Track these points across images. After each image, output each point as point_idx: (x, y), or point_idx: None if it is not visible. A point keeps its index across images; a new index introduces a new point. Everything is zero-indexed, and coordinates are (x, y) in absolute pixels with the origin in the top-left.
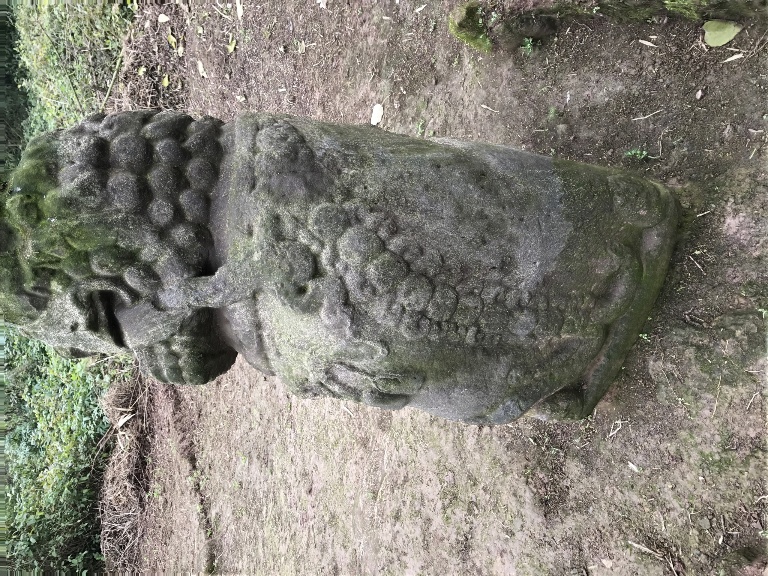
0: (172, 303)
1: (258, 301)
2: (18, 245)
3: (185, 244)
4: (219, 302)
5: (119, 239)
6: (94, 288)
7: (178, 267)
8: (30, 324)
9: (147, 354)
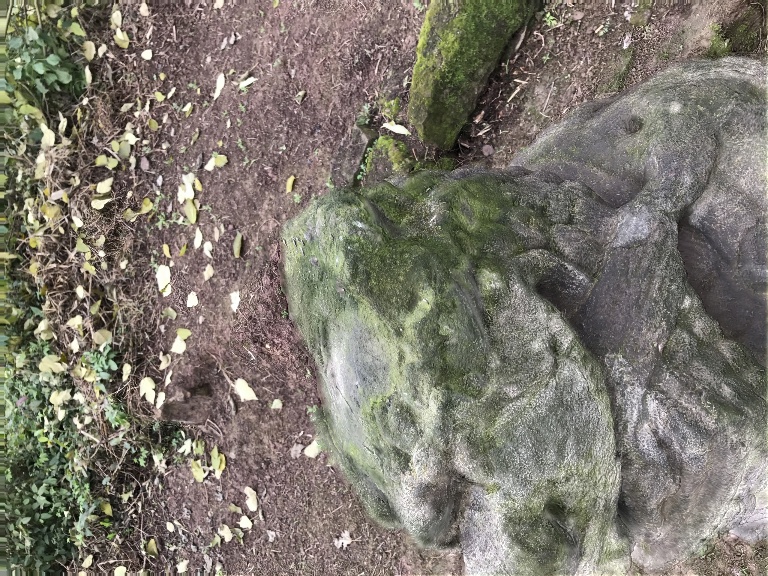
0: (643, 229)
1: (726, 170)
2: (404, 233)
3: (582, 190)
4: (694, 180)
5: (514, 195)
6: (535, 264)
7: (601, 208)
8: (479, 401)
9: (676, 374)
